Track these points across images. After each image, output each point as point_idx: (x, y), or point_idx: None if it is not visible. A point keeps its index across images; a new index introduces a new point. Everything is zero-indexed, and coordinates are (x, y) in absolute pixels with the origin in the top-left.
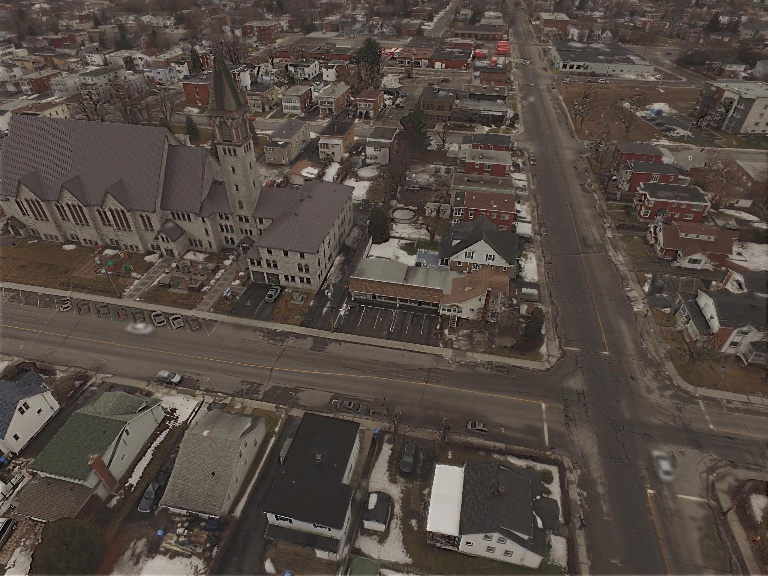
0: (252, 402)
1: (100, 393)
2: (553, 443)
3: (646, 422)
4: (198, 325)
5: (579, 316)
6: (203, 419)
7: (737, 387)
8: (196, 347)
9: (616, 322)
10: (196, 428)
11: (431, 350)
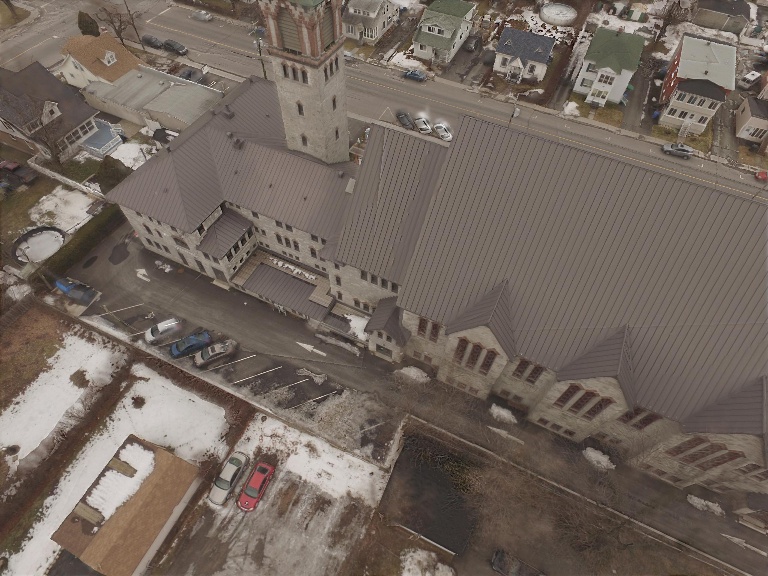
0: (351, 55)
1: (469, 78)
2: (166, 8)
3: (95, 4)
4: (400, 118)
5: (28, 63)
6: (378, 6)
7: (4, 5)
8: (399, 97)
9: (4, 54)
10: (381, 0)
11: (193, 63)
